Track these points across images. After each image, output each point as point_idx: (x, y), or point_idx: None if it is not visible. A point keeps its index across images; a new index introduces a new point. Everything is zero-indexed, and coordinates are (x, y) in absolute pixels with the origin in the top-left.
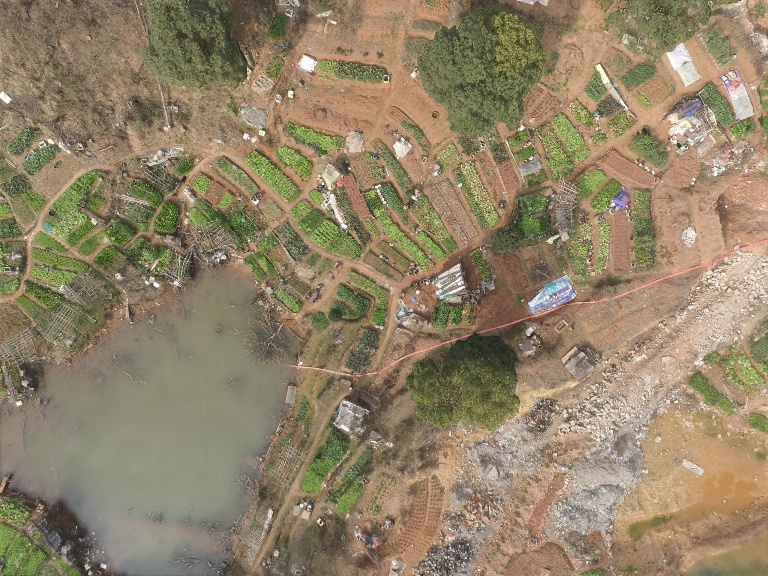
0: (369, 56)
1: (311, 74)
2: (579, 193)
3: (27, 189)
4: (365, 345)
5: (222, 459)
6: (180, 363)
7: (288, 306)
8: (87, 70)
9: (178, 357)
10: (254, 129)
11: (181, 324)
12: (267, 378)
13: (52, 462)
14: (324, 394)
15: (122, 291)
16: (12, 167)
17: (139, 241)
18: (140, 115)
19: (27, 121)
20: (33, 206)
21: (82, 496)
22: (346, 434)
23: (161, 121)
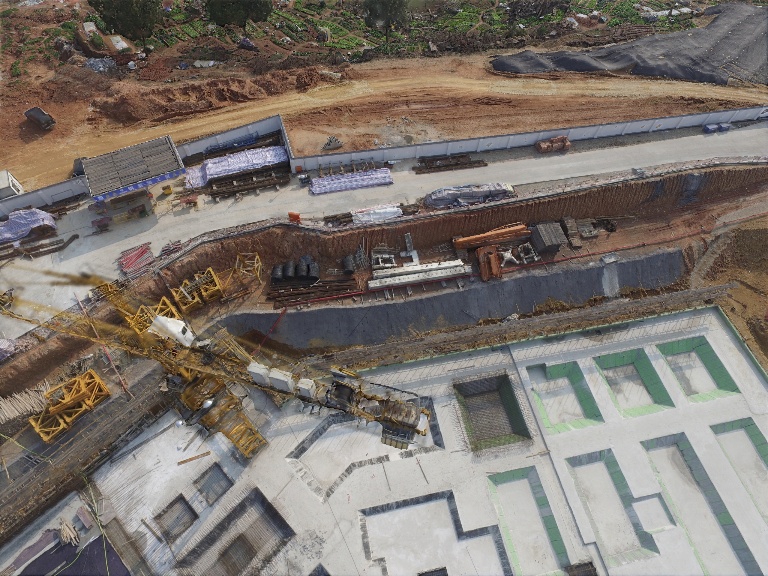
0: None
1: None
2: (188, 14)
3: None
4: None
5: None
6: None
7: None
8: None
9: None
10: None
11: None
12: None
13: None
14: None
15: None
16: None
17: None
18: None
19: None
20: None
21: None
22: None
23: None
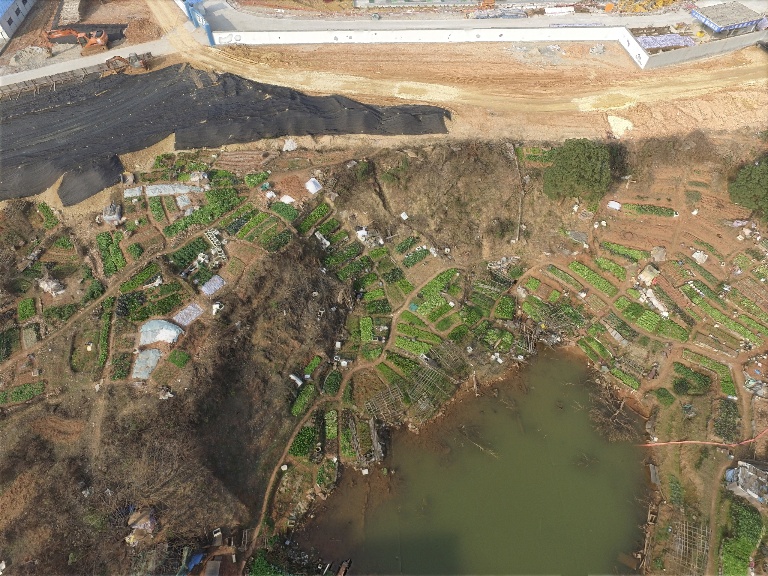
0: (661, 201)
1: (619, 211)
2: None
3: (401, 279)
4: (727, 414)
5: (590, 556)
6: (527, 438)
7: (627, 383)
8: (471, 199)
9: (524, 431)
10: (579, 244)
11: (522, 400)
12: (620, 457)
13: (398, 546)
14: (703, 464)
15: (469, 364)
16: (394, 262)
17: (484, 323)
18: (501, 229)
19: (413, 232)
20: (404, 291)
21: None
22: (751, 506)
23: (511, 236)
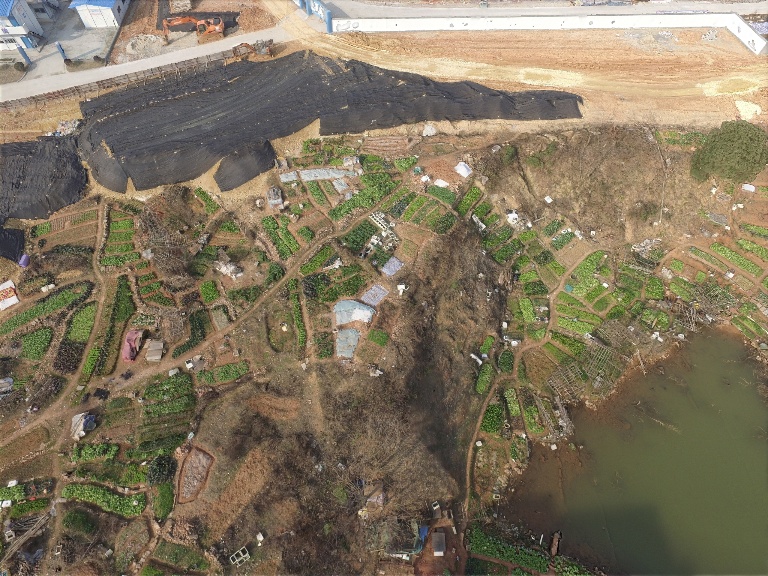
0: None
1: (755, 193)
2: None
3: (551, 261)
4: None
5: None
6: (701, 413)
7: None
8: (614, 182)
9: (697, 407)
10: (719, 226)
11: (688, 377)
12: None
13: (603, 517)
14: None
15: (632, 343)
16: (543, 245)
17: (638, 304)
18: (645, 211)
19: (557, 216)
20: (557, 272)
21: (646, 566)
22: None
23: (653, 218)
